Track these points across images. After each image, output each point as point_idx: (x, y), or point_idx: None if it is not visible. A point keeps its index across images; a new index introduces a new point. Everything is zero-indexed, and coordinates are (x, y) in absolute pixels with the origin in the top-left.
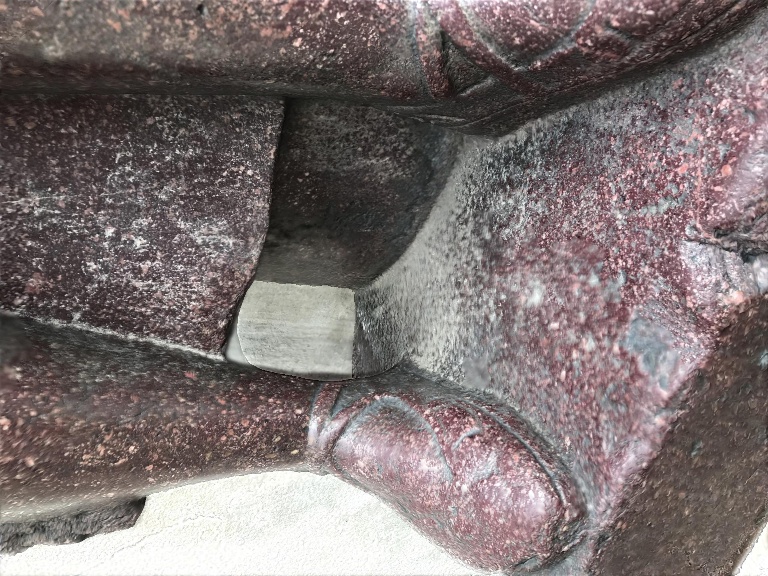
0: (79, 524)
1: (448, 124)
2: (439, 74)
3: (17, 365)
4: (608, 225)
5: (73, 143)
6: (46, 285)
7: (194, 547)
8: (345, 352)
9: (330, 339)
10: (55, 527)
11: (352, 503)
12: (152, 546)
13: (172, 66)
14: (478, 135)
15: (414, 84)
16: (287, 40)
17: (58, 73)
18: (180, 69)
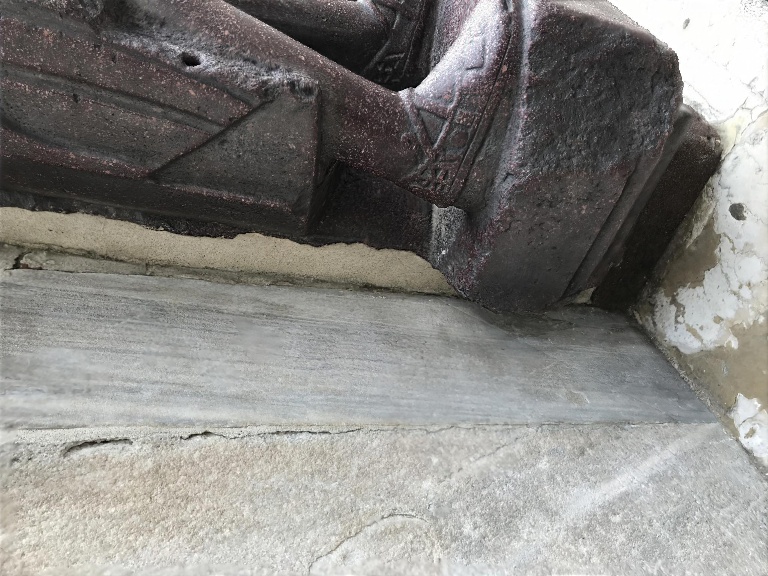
0: None
1: (401, 63)
2: (379, 13)
3: None
4: (460, 4)
5: None
6: None
7: (409, 570)
8: (459, 349)
9: (441, 339)
10: None
11: (572, 511)
12: (356, 558)
13: (293, 6)
14: (420, 82)
15: (373, 20)
16: (326, 3)
17: (260, 3)
18: (295, 9)
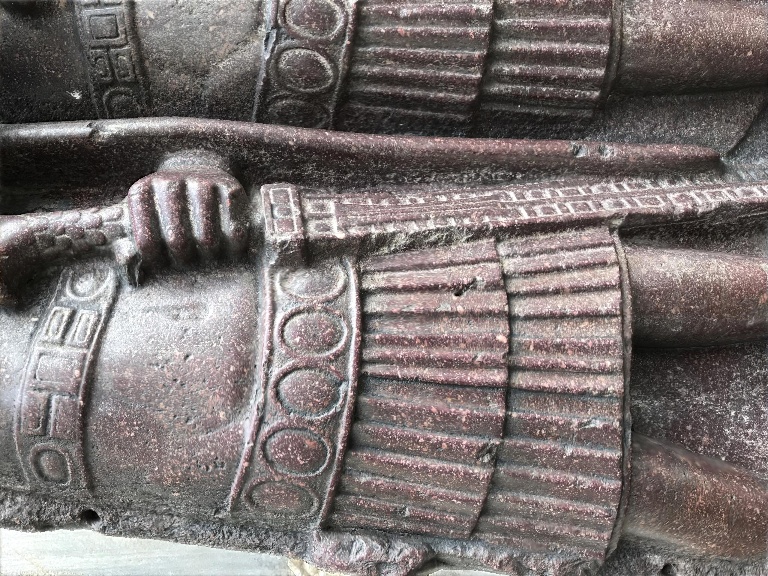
0: (763, 571)
1: None
2: None
3: (733, 467)
4: None
5: (717, 370)
6: (710, 441)
7: None
8: None
9: None
10: (752, 571)
11: None
12: None
13: None
14: None
15: None
16: None
17: None
18: None
